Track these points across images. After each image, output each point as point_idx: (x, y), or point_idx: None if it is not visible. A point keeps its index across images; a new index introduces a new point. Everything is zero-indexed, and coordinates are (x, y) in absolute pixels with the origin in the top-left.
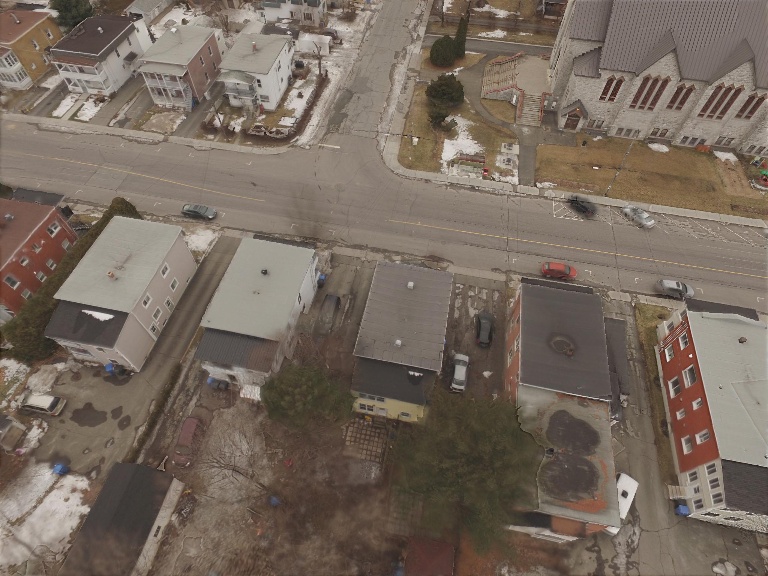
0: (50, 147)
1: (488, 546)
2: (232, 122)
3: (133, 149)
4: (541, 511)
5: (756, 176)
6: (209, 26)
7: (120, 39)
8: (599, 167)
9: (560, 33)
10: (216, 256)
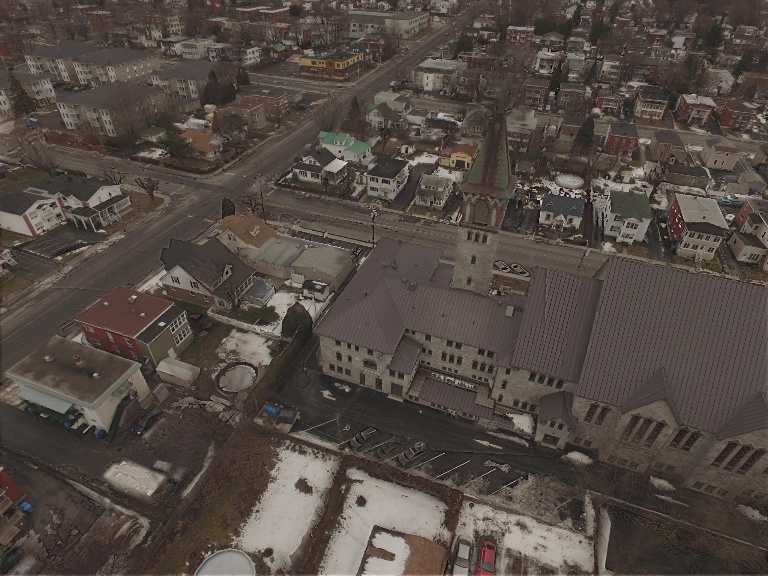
0: None
1: None
2: None
3: None
4: None
5: None
6: None
7: None
8: None
9: None
10: None
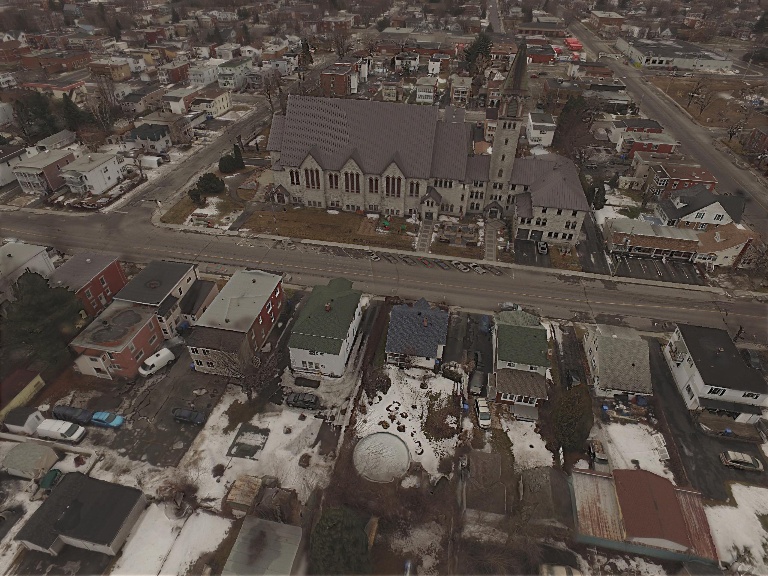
0: None
1: (71, 383)
2: (67, 201)
3: None
4: (82, 346)
5: (383, 225)
6: (86, 152)
7: (11, 156)
8: None
9: None
10: None
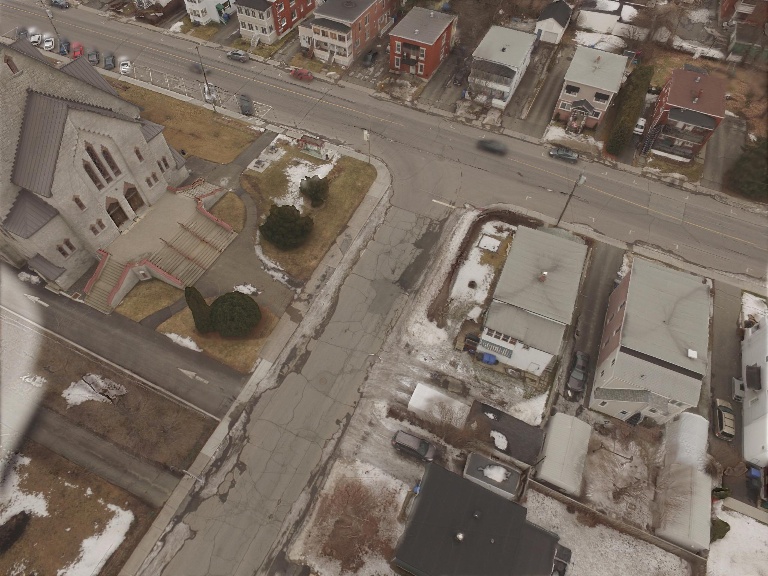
0: (760, 258)
1: (407, 9)
2: None
3: (661, 238)
4: None
5: None
6: None
7: None
8: (222, 89)
9: (92, 207)
10: (541, 123)
